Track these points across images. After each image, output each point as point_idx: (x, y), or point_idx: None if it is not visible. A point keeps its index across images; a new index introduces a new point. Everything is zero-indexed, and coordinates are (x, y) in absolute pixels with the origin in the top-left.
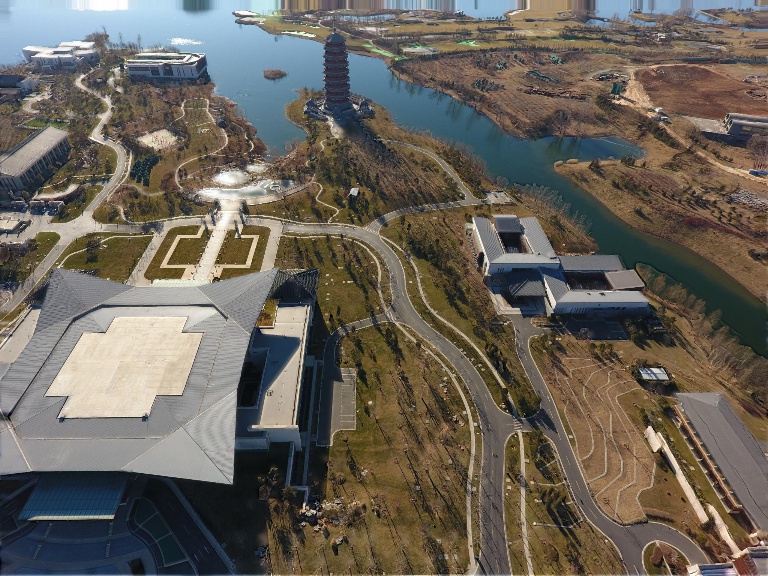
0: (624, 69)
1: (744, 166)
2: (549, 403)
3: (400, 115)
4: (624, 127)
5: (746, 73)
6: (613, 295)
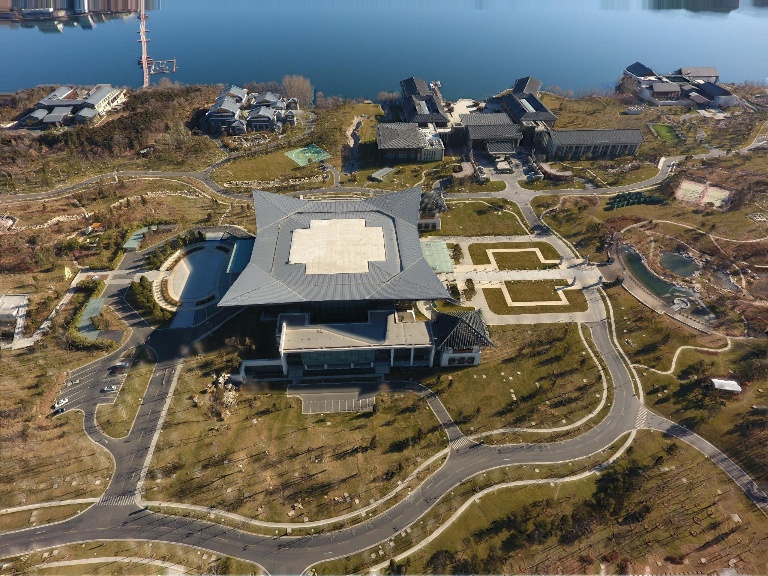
0: None
1: None
2: None
3: None
4: None
5: None
6: None
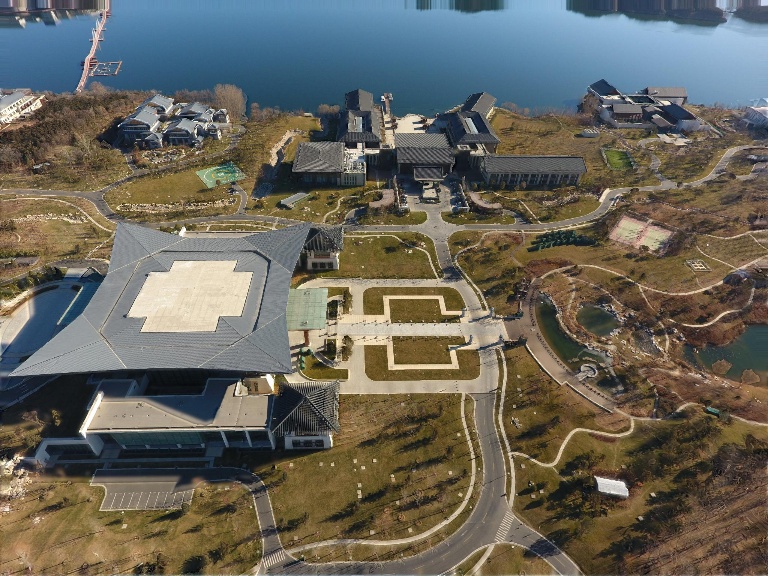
0: None
1: None
2: None
3: None
4: None
5: None
6: None
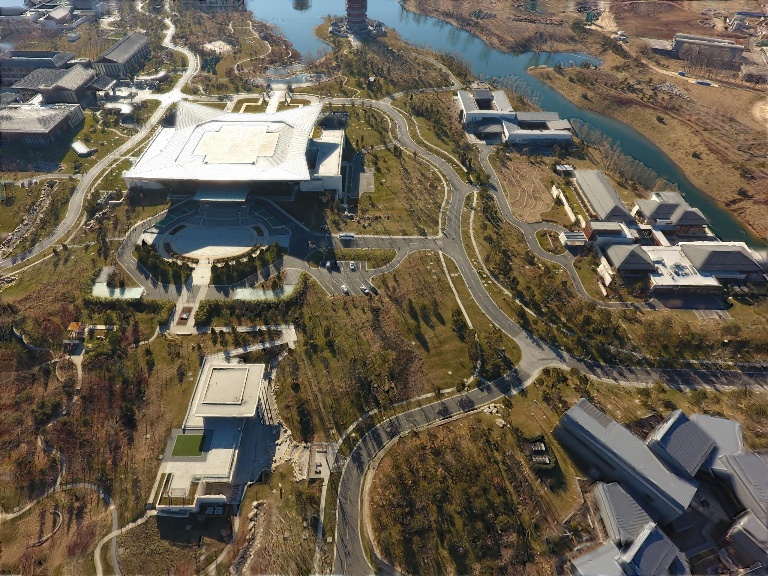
0: (602, 4)
1: (677, 71)
2: (496, 181)
3: (408, 36)
4: (590, 45)
5: (705, 7)
6: (549, 132)
